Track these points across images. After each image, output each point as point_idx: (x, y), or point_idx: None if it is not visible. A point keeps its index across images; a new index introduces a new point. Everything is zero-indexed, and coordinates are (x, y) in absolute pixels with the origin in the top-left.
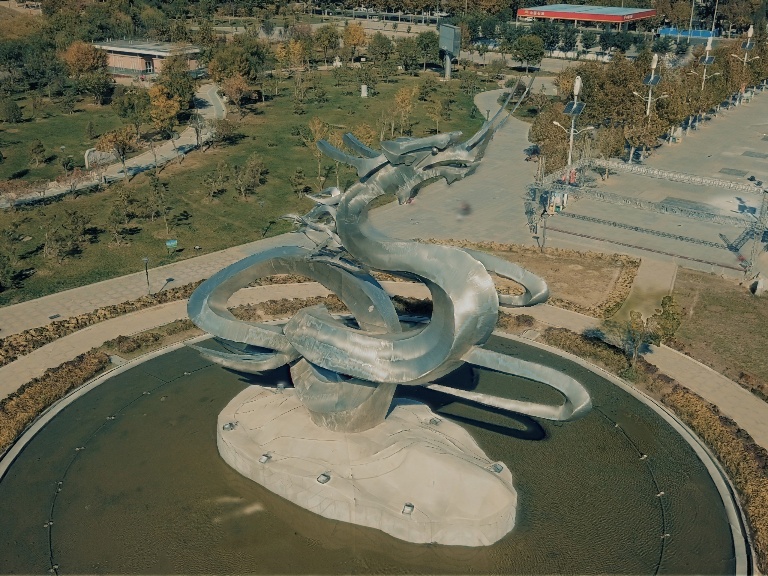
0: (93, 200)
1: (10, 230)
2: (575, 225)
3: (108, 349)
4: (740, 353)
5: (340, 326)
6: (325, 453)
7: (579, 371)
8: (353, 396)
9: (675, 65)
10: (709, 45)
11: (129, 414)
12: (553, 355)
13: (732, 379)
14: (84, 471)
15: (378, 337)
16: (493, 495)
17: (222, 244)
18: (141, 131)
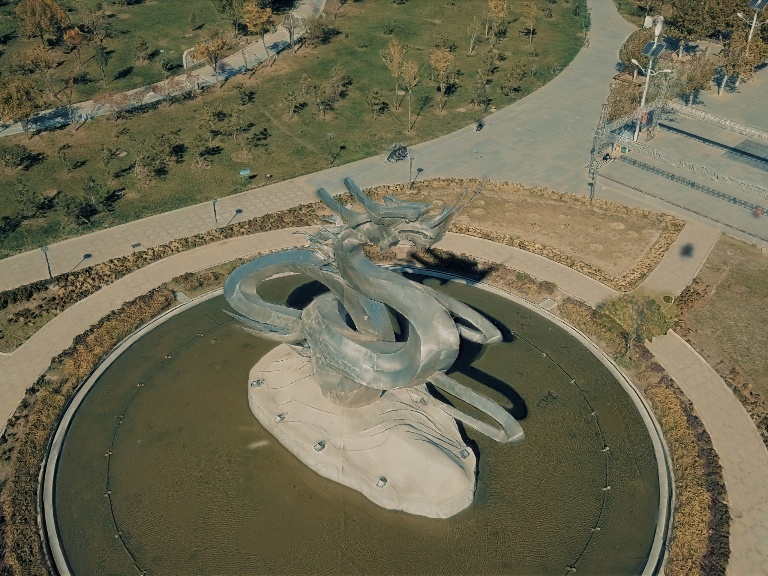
0: (185, 110)
1: (105, 155)
2: (632, 175)
3: (176, 285)
4: (742, 345)
5: (341, 327)
6: (325, 423)
7: (580, 350)
8: (351, 381)
9: None
10: None
11: (184, 354)
12: (561, 330)
13: (721, 374)
14: (141, 407)
15: (366, 346)
16: (451, 481)
17: (292, 172)
18: (240, 23)
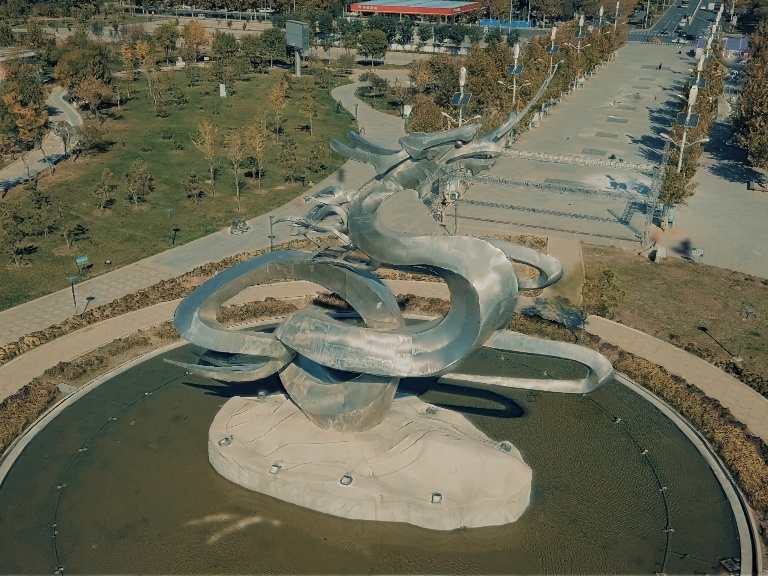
0: None
1: None
2: (477, 211)
3: (50, 378)
4: (662, 316)
5: (347, 326)
6: (339, 455)
7: None
8: (362, 395)
9: (522, 54)
10: (554, 35)
11: (101, 443)
12: None
13: (665, 340)
14: (75, 509)
15: (394, 333)
16: (515, 473)
17: (132, 256)
18: None
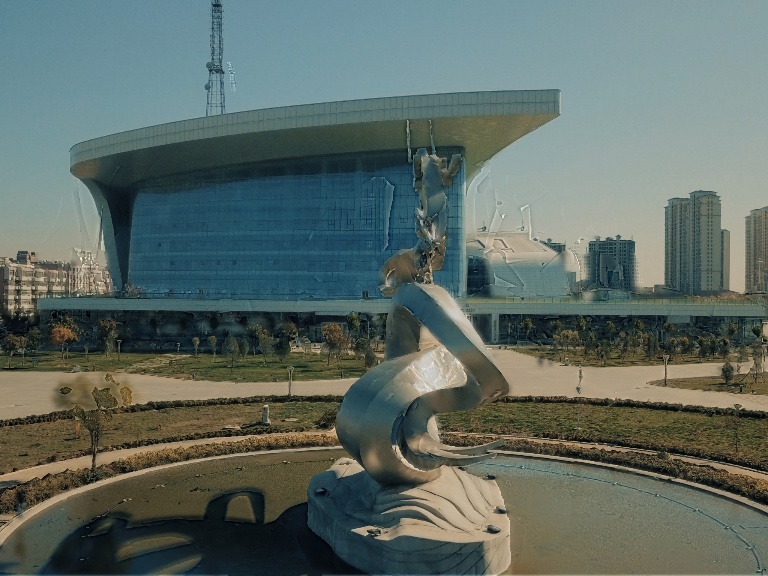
0: None
1: None
2: None
3: None
4: None
5: None
6: None
7: (91, 495)
8: None
9: None
10: None
11: None
12: (59, 504)
13: None
14: None
15: None
16: None
17: None
18: None
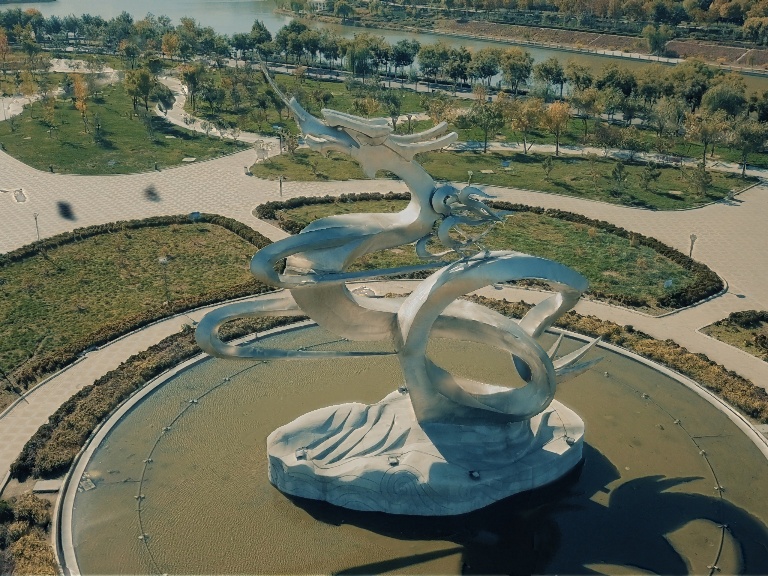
0: None
1: None
2: None
3: None
4: None
5: None
6: None
7: None
8: None
9: None
10: None
11: None
12: None
13: None
14: None
15: (390, 299)
16: None
17: None
18: None
